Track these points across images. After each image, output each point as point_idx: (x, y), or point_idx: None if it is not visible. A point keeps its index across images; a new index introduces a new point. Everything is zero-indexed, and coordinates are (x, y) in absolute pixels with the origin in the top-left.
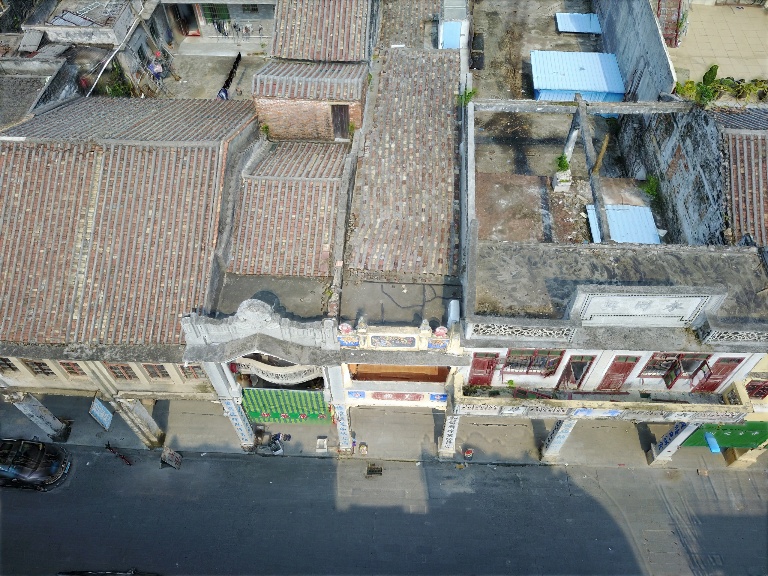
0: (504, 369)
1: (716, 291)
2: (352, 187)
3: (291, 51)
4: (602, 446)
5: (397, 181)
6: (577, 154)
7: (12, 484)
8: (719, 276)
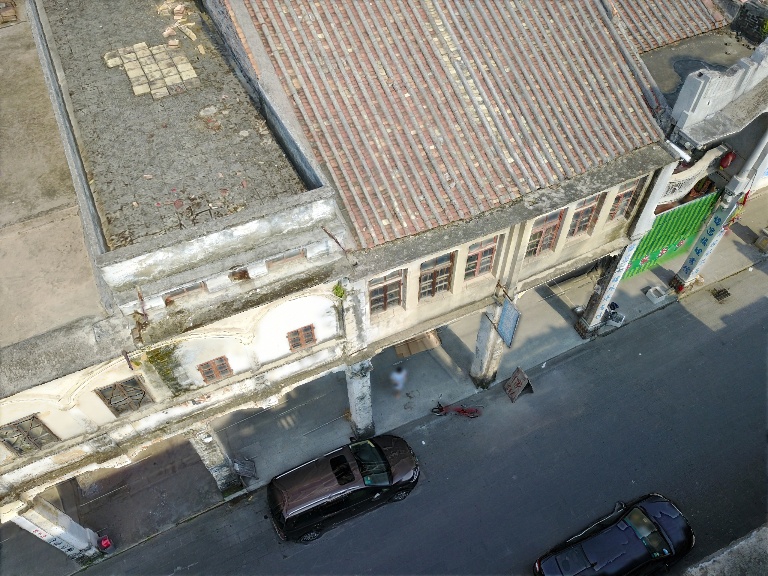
0: None
1: None
2: None
3: None
4: None
5: None
6: None
7: (364, 509)
8: None
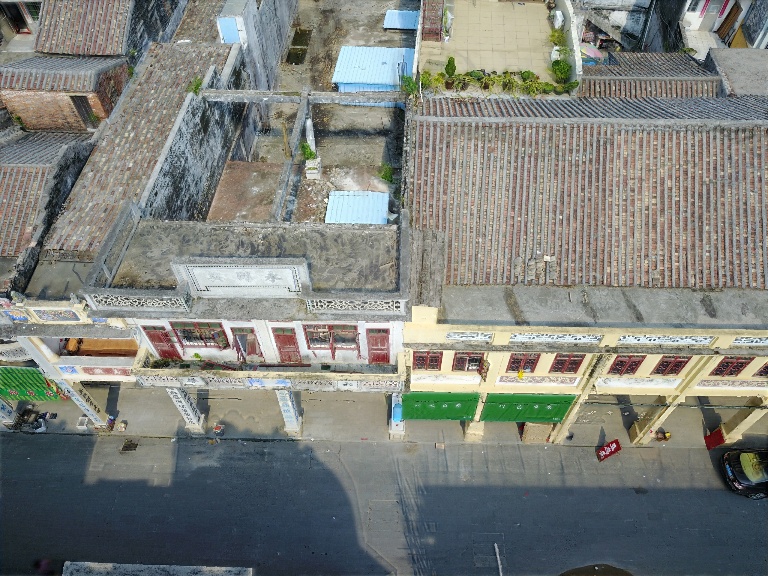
0: (184, 342)
1: (295, 262)
2: (77, 173)
3: (53, 46)
4: (350, 422)
5: (122, 168)
6: (367, 145)
7: None
8: (353, 251)
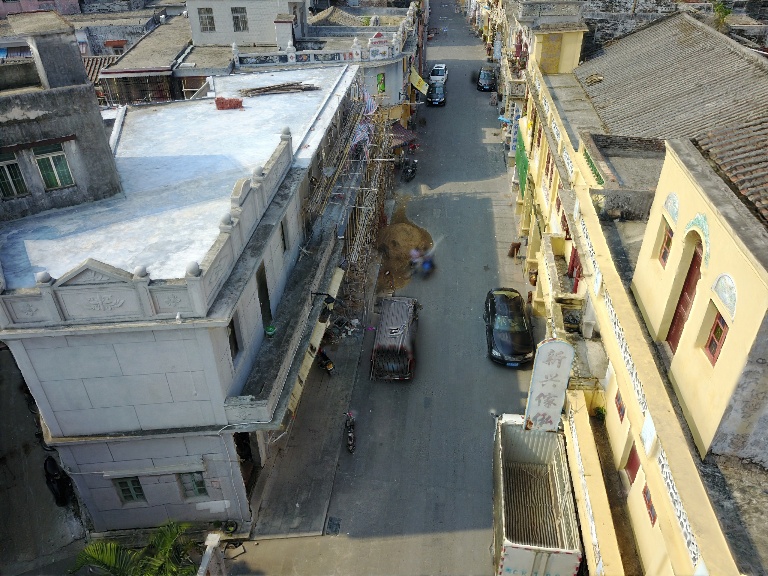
0: None
1: None
2: None
3: None
4: None
5: None
6: None
7: None
8: None
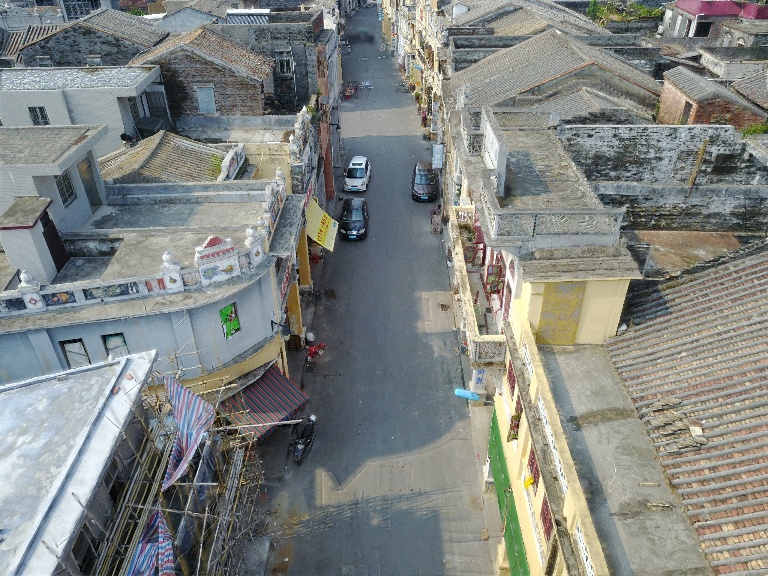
0: None
1: (501, 140)
2: None
3: (745, 87)
4: None
5: None
6: None
7: None
8: None
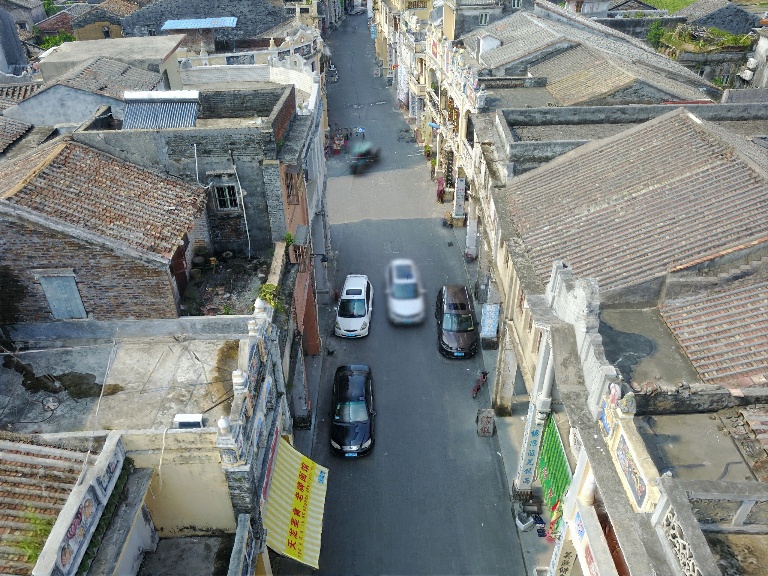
0: None
1: None
2: None
3: None
4: None
5: None
6: None
7: None
8: None
